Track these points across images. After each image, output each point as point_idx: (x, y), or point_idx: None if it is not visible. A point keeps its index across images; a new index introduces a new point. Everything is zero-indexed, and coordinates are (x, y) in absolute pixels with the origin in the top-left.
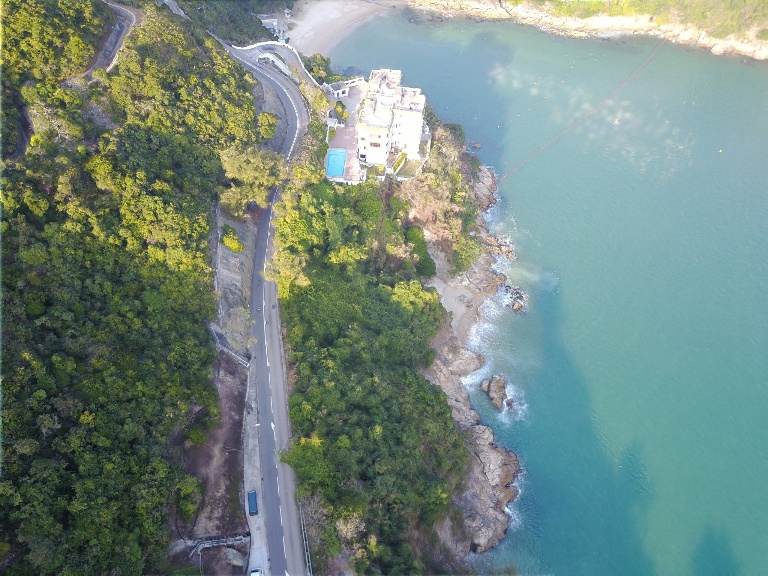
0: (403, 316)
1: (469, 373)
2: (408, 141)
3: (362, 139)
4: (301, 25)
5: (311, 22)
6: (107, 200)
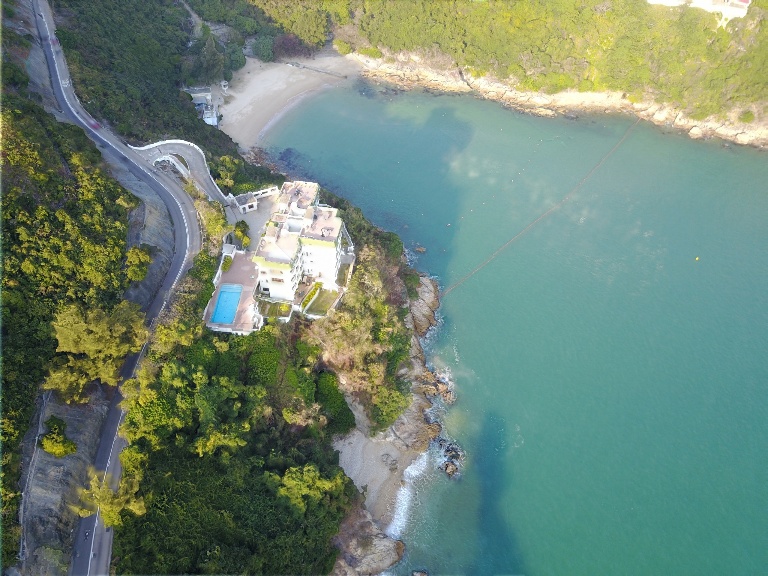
0: (293, 514)
1: (383, 569)
2: (322, 270)
3: (263, 272)
4: (239, 98)
5: (251, 95)
6: None
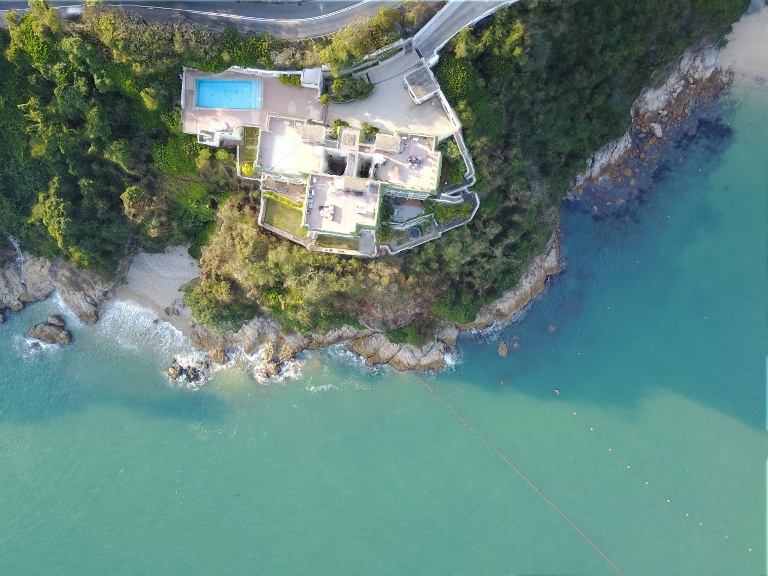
0: None
1: None
2: None
3: None
4: None
5: None
6: None
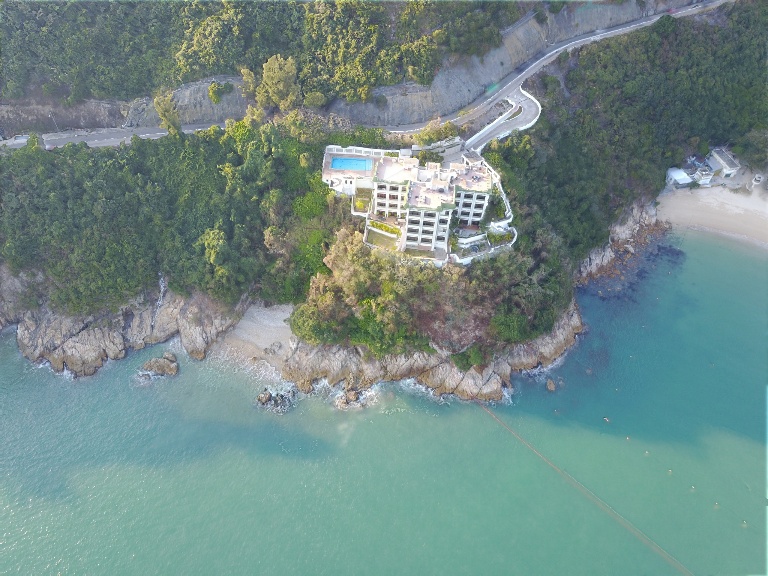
0: None
1: None
2: None
3: None
4: (751, 200)
5: (765, 208)
6: (215, 8)
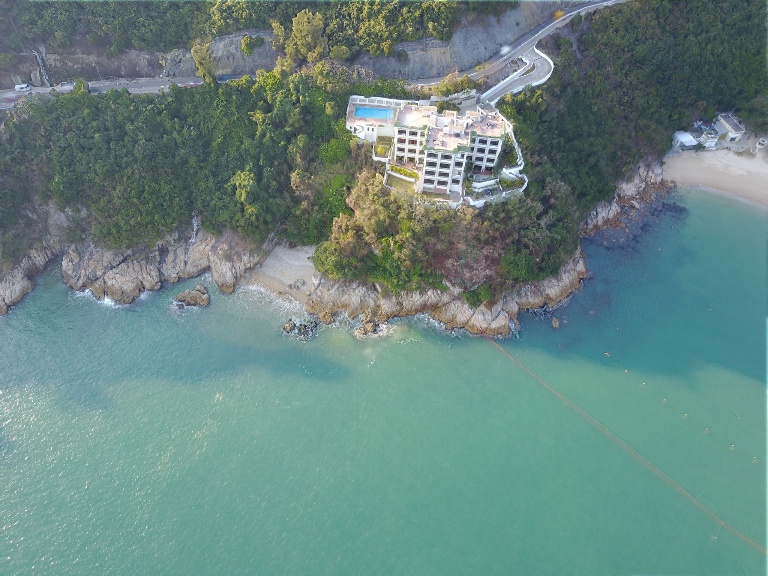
0: None
1: None
2: None
3: None
4: (754, 162)
5: (767, 171)
6: None
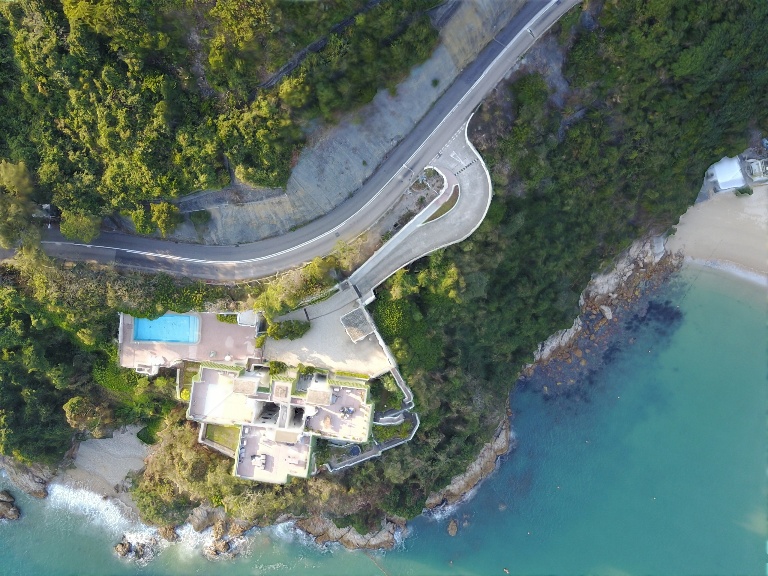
0: None
1: None
2: None
3: None
4: None
5: None
6: None
